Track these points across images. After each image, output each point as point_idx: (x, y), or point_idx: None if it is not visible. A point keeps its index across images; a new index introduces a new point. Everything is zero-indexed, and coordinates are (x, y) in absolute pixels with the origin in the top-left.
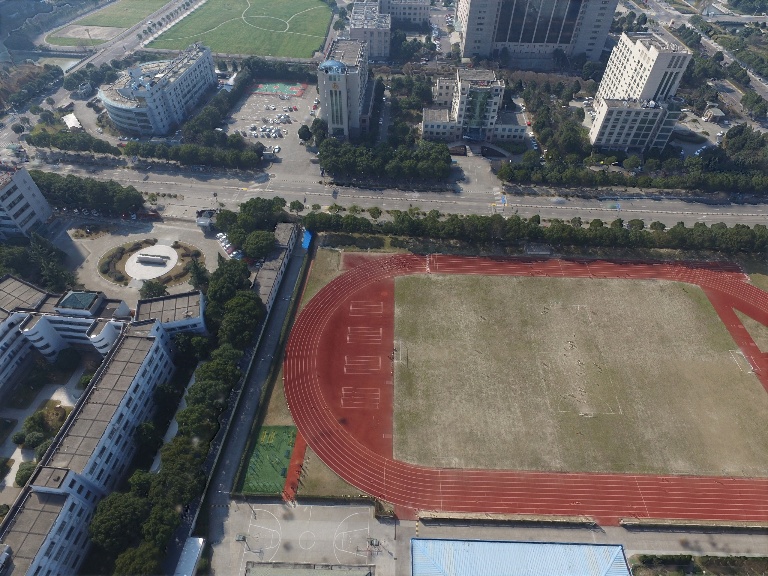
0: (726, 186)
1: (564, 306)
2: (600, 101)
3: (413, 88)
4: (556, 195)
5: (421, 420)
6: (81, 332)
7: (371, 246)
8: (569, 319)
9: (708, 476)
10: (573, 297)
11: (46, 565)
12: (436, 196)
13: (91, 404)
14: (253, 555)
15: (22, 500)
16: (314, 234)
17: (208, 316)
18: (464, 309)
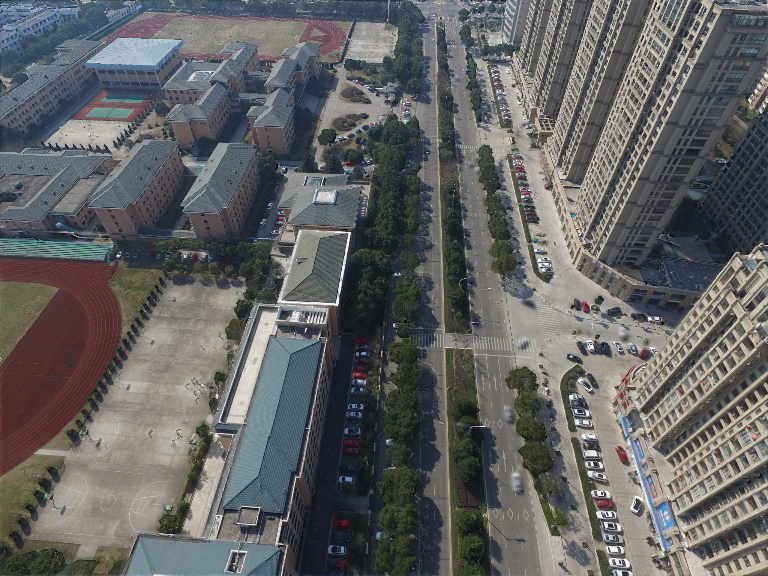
0: None
1: (240, 26)
2: None
3: None
4: (275, 1)
5: None
6: None
7: (170, 12)
8: None
9: None
10: (247, 24)
11: (6, 44)
12: None
13: (27, 20)
14: None
15: (0, 31)
16: (145, 8)
17: (80, 13)
18: (196, 26)
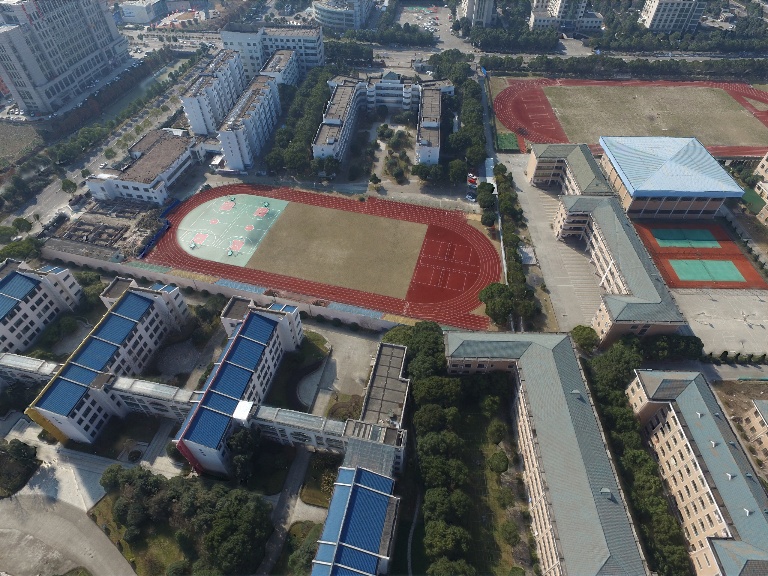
0: (737, 46)
1: (644, 96)
2: (648, 10)
3: (519, 2)
4: (628, 55)
5: (579, 131)
6: (390, 96)
7: (521, 76)
8: (648, 100)
9: (732, 146)
10: (649, 93)
11: None
12: (551, 56)
13: (425, 107)
14: (516, 166)
15: None
16: None
17: (456, 89)
18: (587, 98)
